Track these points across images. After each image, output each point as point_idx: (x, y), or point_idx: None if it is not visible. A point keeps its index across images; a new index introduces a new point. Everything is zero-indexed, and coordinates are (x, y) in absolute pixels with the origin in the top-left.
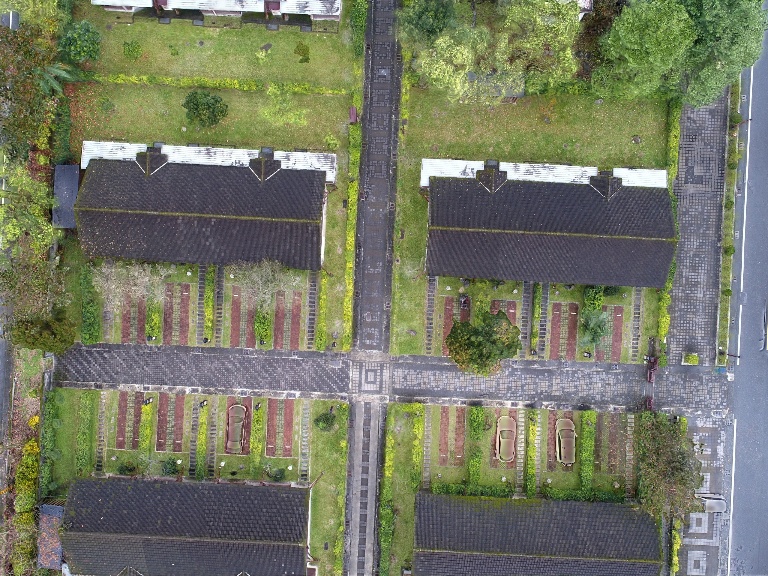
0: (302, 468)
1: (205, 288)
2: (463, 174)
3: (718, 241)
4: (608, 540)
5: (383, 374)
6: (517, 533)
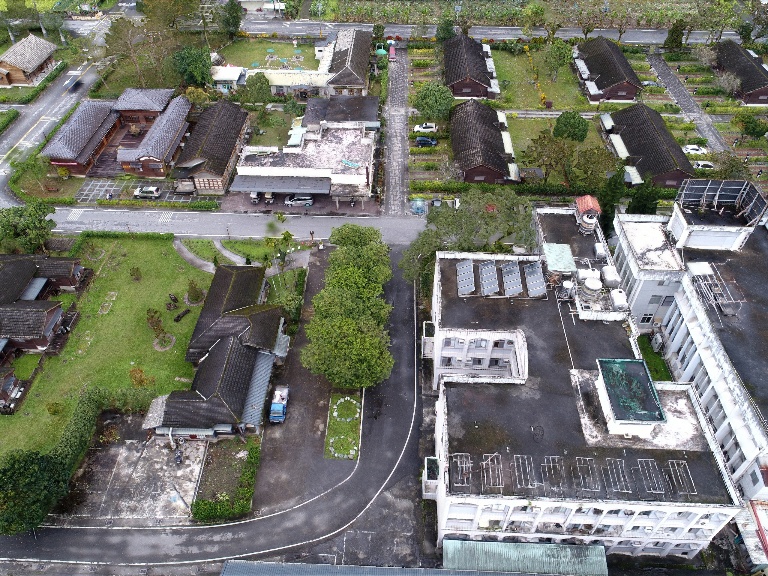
0: (643, 101)
1: (710, 77)
2: None
3: None
4: None
5: (701, 121)
6: None
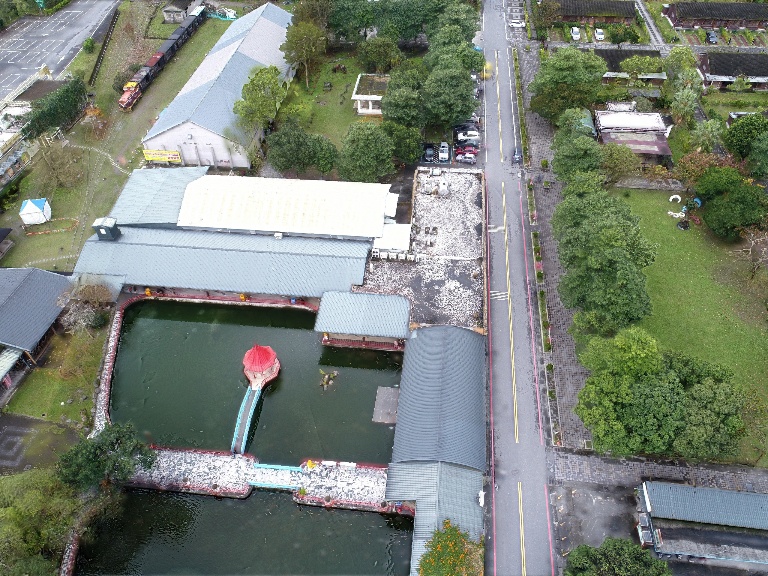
0: None
1: None
2: (647, 74)
3: (521, 72)
4: (563, 5)
5: None
6: (597, 6)
